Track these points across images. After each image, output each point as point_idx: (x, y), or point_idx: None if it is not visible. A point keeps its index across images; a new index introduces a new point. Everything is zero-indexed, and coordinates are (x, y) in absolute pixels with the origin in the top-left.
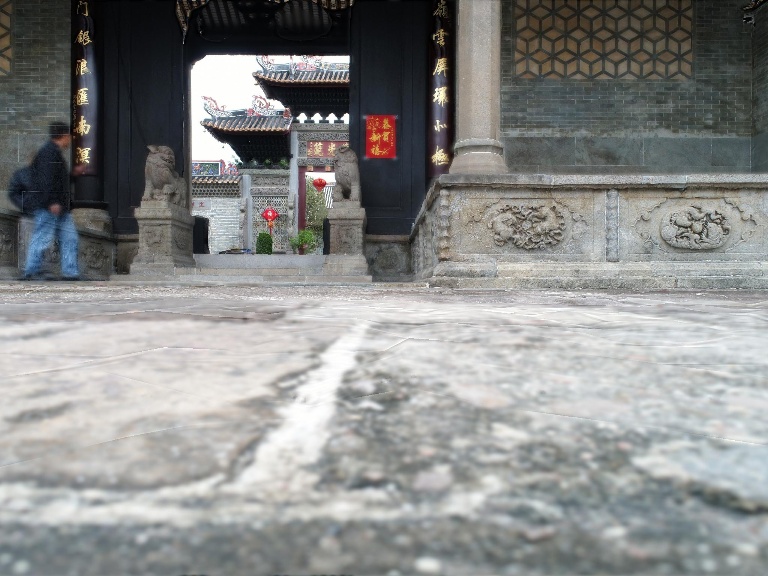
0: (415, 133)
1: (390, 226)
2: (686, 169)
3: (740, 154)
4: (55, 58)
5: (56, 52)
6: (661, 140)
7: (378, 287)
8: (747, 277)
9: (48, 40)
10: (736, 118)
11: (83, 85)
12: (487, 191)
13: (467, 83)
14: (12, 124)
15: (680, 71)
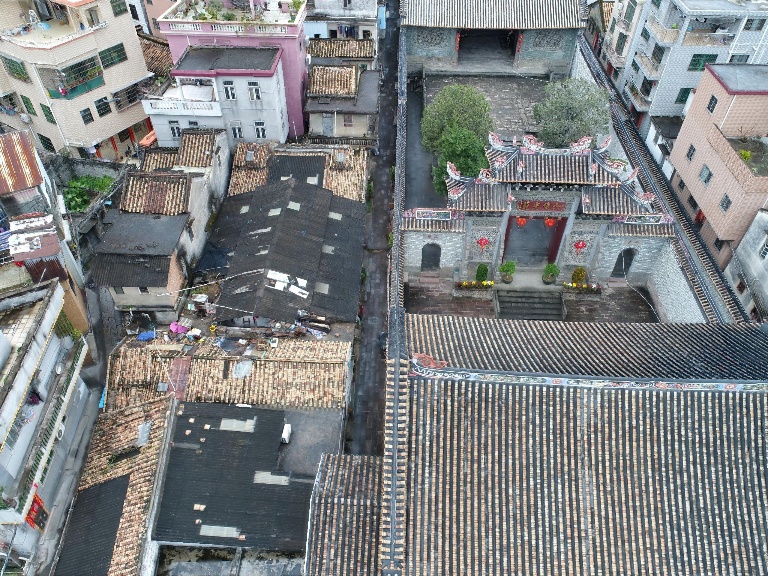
0: None
1: None
2: None
3: None
4: None
5: None
6: None
7: None
8: None
9: None
10: None
11: None
12: None
13: None
14: None
15: None
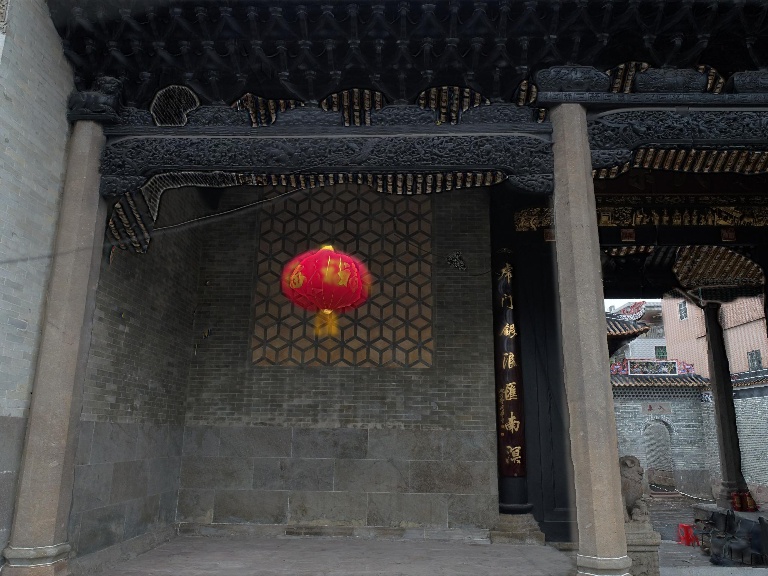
0: None
1: None
2: None
3: None
4: (478, 350)
5: (479, 344)
6: None
7: None
8: None
9: (470, 332)
10: None
11: (506, 377)
12: None
13: None
14: (435, 419)
15: None
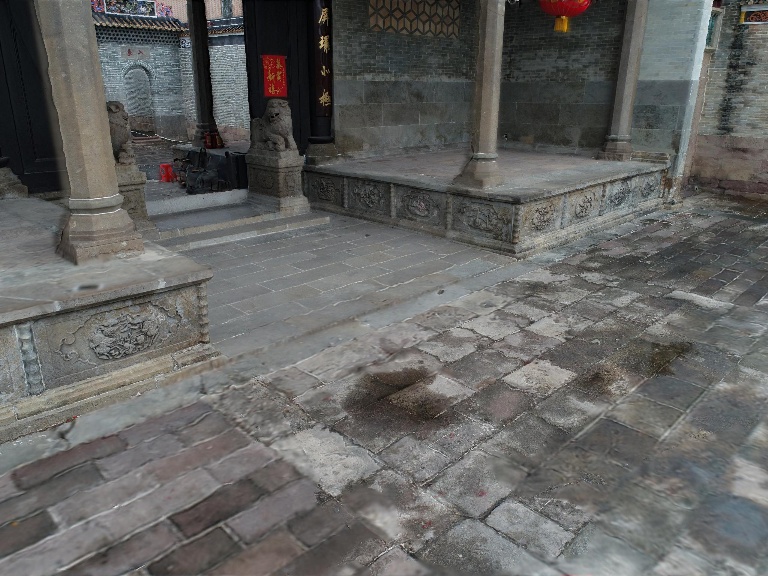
0: (301, 74)
1: None
2: (453, 104)
3: None
4: None
5: None
6: (443, 84)
7: (509, 268)
8: (597, 227)
9: None
10: None
11: None
12: (532, 202)
13: (488, 116)
14: None
15: (453, 32)
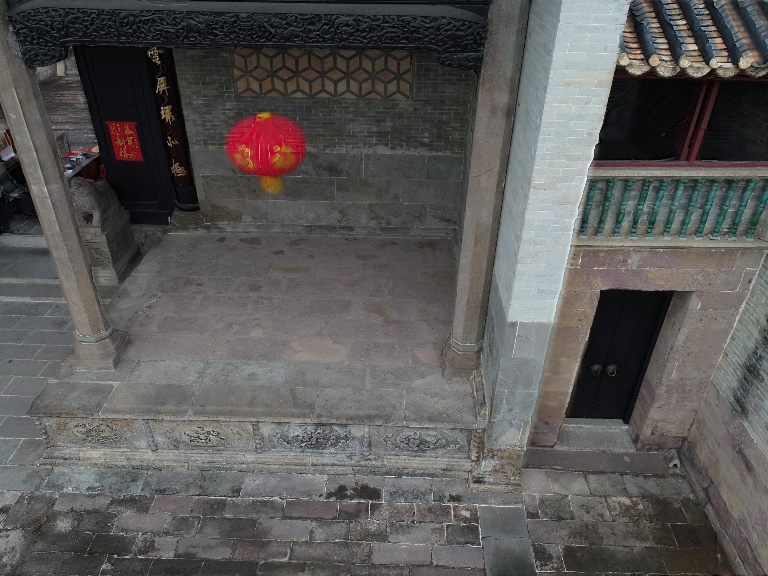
0: (155, 140)
1: (150, 218)
2: (402, 182)
3: (452, 170)
4: None
5: None
6: (380, 156)
7: (2, 473)
8: (231, 466)
9: None
10: (451, 137)
11: None
12: None
13: None
14: None
15: (399, 91)
